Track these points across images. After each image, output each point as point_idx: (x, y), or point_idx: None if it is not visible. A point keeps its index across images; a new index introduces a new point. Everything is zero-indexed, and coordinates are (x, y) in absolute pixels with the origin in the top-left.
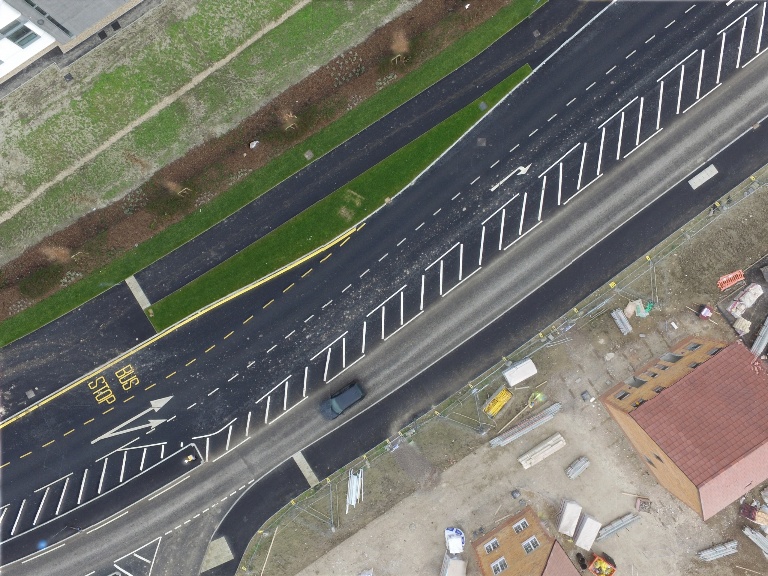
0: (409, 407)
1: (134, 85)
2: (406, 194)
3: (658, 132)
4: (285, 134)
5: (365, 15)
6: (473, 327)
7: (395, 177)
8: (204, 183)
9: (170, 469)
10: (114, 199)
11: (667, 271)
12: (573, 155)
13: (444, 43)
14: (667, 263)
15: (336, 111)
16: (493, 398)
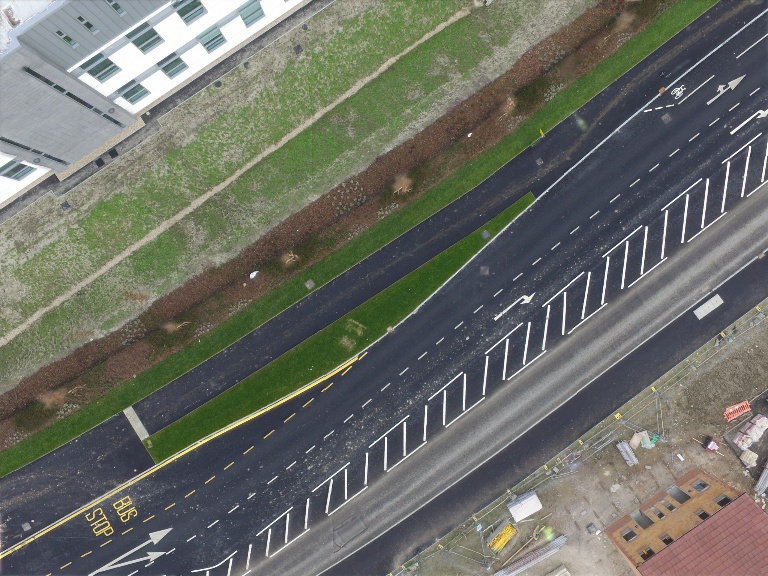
0: (412, 540)
1: (132, 211)
2: (408, 323)
3: (663, 261)
4: (286, 265)
5: (366, 143)
6: (477, 458)
7: (397, 306)
8: (203, 313)
9: None
10: (112, 329)
11: (673, 401)
12: (577, 284)
13: (446, 172)
14: (673, 394)
15: (337, 240)
16: (498, 533)
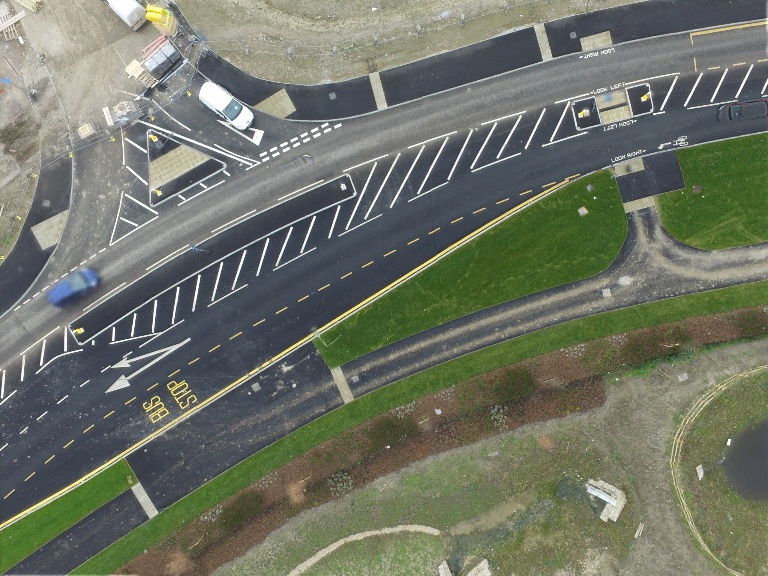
0: None
1: None
2: None
3: None
4: None
5: None
6: None
7: None
8: None
9: (102, 317)
10: None
11: None
12: None
13: None
14: None
15: None
16: None
